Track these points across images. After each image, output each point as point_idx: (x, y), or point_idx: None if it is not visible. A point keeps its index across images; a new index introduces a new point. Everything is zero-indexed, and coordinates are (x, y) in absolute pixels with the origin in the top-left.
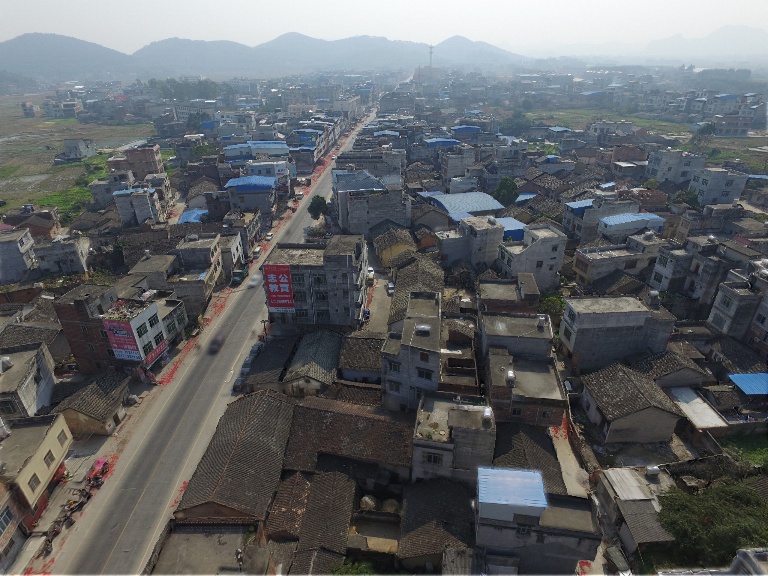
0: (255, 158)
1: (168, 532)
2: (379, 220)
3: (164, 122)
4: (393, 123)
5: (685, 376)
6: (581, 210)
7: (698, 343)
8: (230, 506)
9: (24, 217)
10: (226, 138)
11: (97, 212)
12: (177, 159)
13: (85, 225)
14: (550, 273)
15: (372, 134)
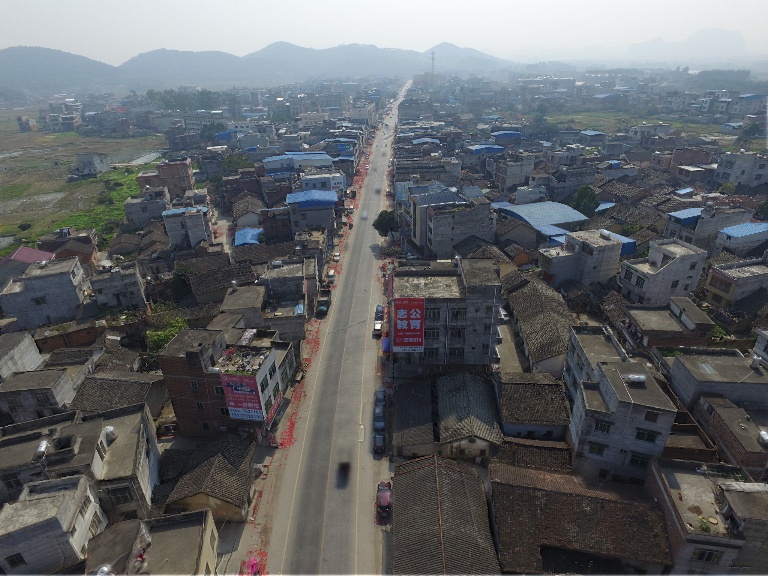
0: (297, 170)
1: None
2: (464, 236)
3: (176, 134)
4: (430, 130)
5: None
6: (689, 220)
7: None
8: None
9: (61, 242)
10: (251, 149)
11: (136, 233)
12: (200, 172)
13: (126, 248)
14: (684, 293)
15: (410, 142)
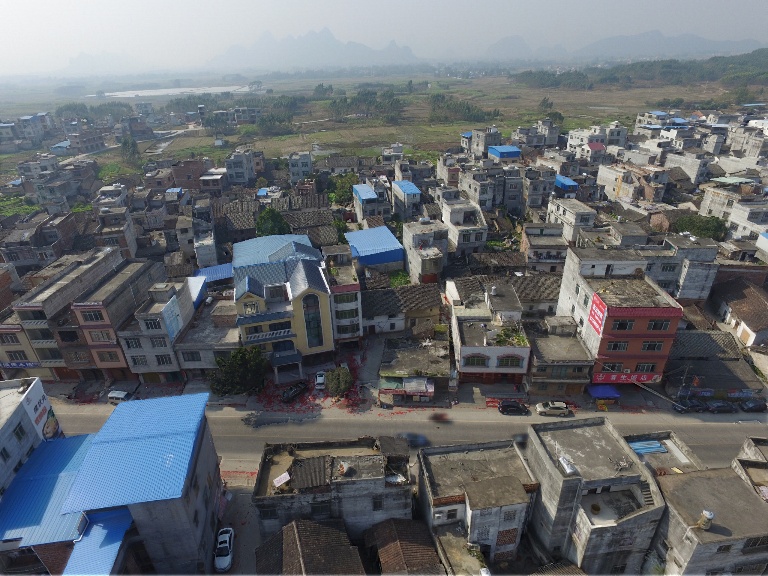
0: None
1: None
2: None
3: None
4: None
5: None
6: None
7: None
8: None
9: None
10: None
11: None
12: None
13: None
14: None
15: None
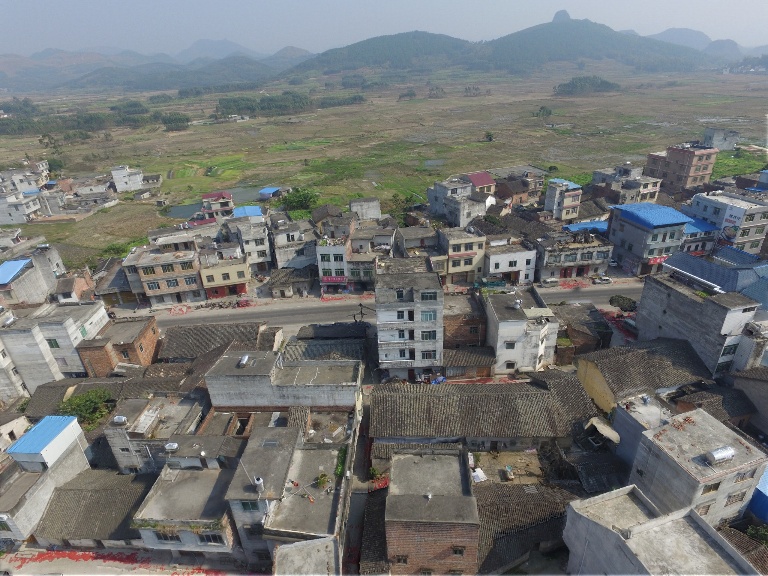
0: None
1: (148, 318)
2: (676, 334)
3: None
4: None
5: None
6: None
7: None
8: (165, 338)
9: None
10: None
11: None
12: None
13: None
14: None
15: None
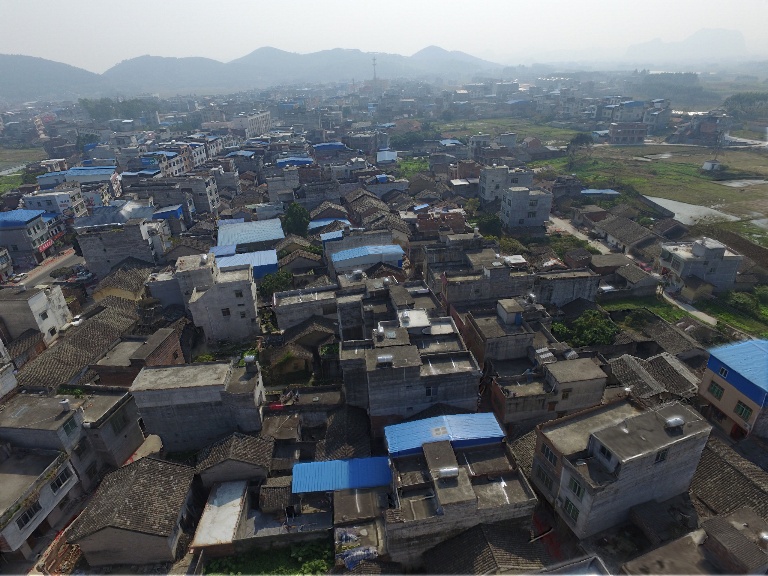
0: None
1: None
2: (121, 258)
3: (55, 145)
4: (254, 142)
5: (238, 468)
6: None
7: (319, 414)
8: None
9: None
10: (87, 162)
11: None
12: None
13: None
14: (244, 321)
15: None
